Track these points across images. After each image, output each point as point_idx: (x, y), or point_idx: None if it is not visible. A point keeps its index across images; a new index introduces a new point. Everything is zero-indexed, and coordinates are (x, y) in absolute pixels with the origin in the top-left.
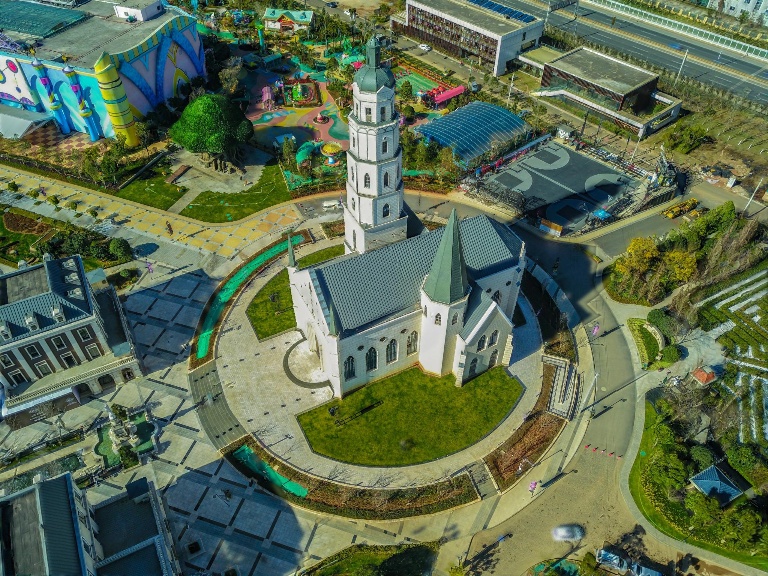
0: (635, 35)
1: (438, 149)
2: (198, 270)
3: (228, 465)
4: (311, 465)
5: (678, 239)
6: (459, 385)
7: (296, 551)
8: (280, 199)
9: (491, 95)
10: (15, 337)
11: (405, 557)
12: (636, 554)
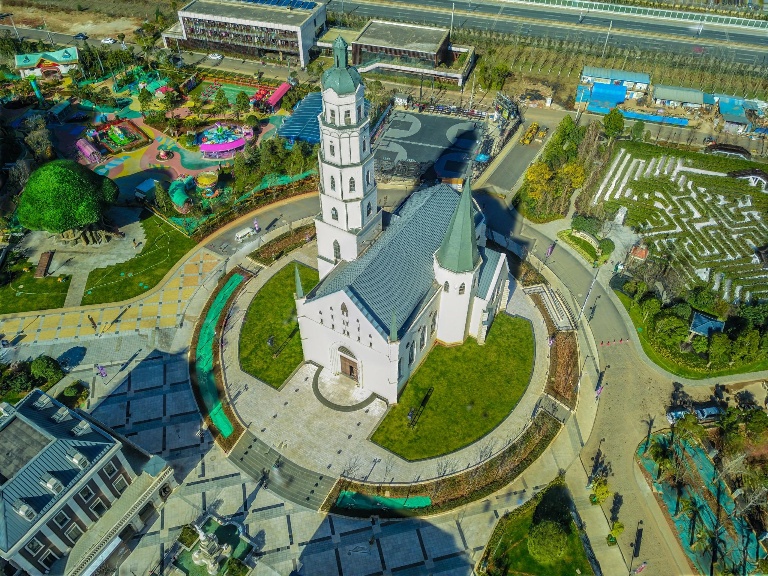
0: (392, 2)
1: (310, 147)
2: (152, 352)
3: (339, 518)
4: (416, 474)
5: (553, 157)
6: (482, 343)
7: (459, 554)
8: (185, 248)
9: (312, 85)
10: (40, 511)
11: (545, 503)
12: (688, 404)
